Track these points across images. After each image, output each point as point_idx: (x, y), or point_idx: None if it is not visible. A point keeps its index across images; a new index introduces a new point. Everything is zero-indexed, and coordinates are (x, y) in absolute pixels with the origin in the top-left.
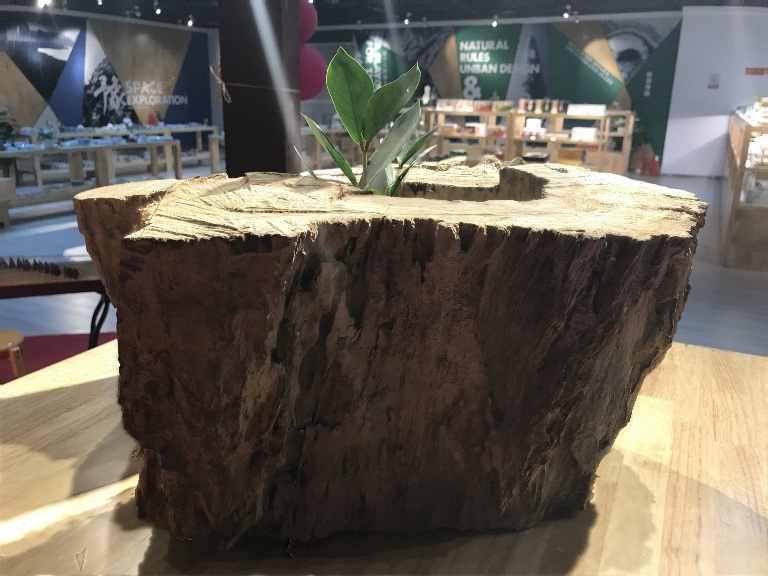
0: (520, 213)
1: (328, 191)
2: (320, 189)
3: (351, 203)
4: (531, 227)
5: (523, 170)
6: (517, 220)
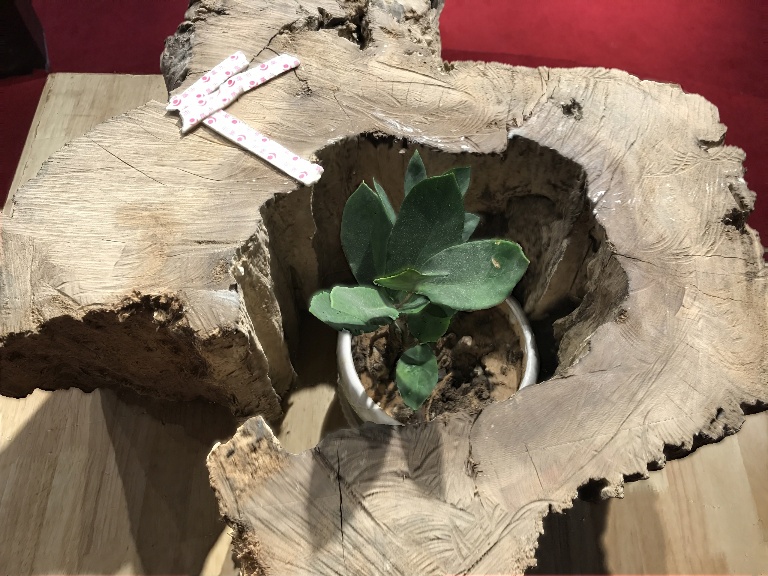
0: (645, 382)
1: (455, 465)
2: (443, 464)
3: (493, 480)
4: (683, 441)
5: (543, 144)
6: (659, 420)
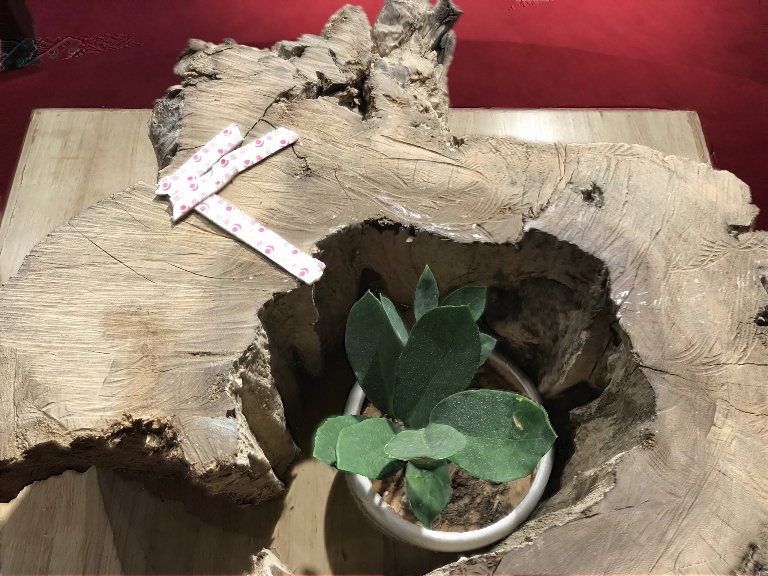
0: (675, 519)
1: None
2: None
3: None
4: None
5: (562, 238)
6: (691, 563)
